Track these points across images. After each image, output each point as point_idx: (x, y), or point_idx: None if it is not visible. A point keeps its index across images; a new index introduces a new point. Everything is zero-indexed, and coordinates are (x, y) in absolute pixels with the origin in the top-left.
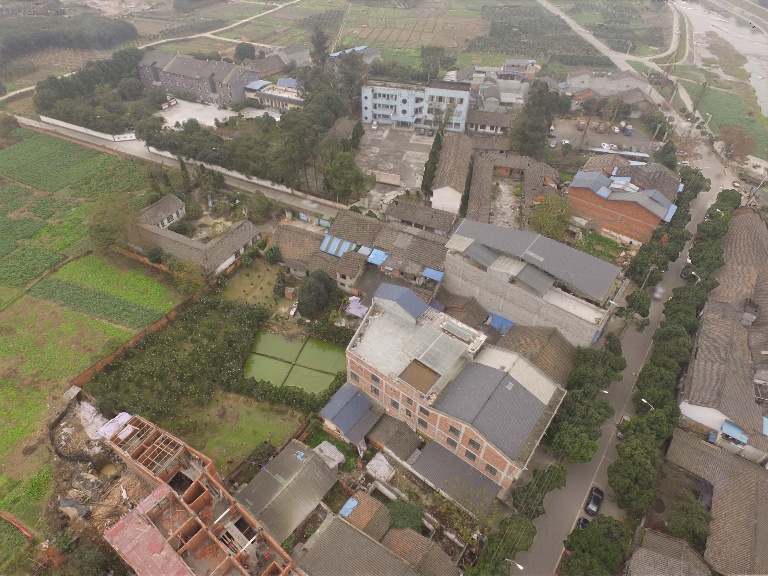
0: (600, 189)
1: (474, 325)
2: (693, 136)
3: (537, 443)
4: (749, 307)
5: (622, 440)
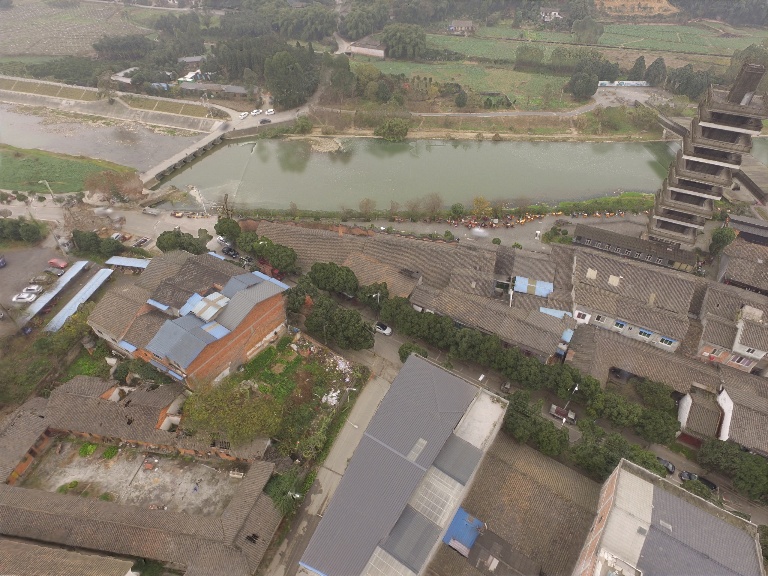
0: (209, 333)
1: (476, 572)
2: (52, 210)
3: (712, 505)
4: (413, 275)
5: None
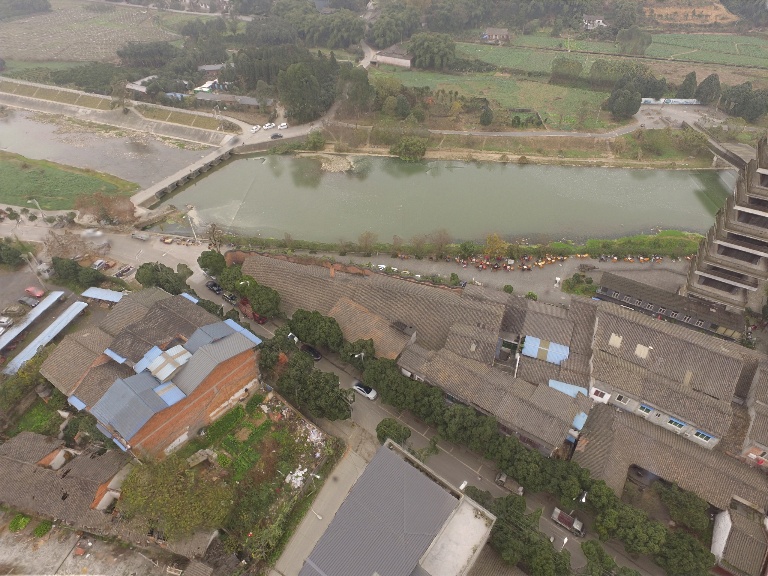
0: (161, 397)
1: None
2: (42, 230)
3: None
4: (405, 330)
5: (587, 533)
